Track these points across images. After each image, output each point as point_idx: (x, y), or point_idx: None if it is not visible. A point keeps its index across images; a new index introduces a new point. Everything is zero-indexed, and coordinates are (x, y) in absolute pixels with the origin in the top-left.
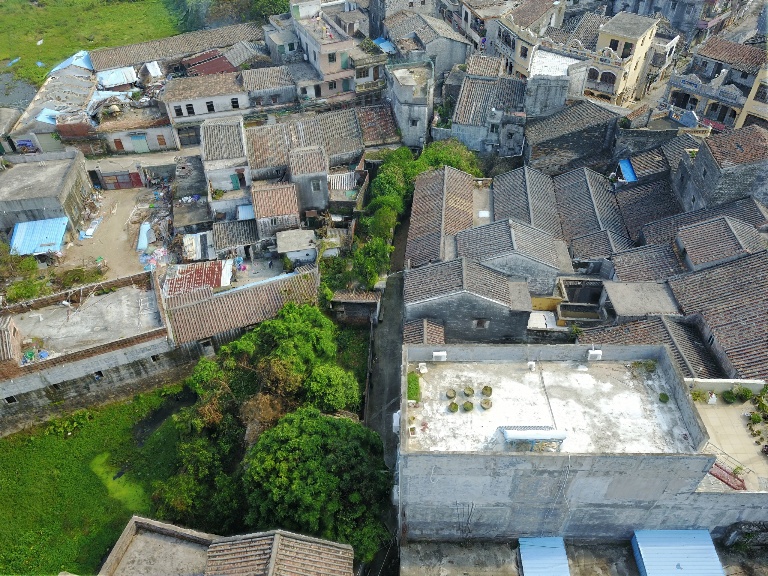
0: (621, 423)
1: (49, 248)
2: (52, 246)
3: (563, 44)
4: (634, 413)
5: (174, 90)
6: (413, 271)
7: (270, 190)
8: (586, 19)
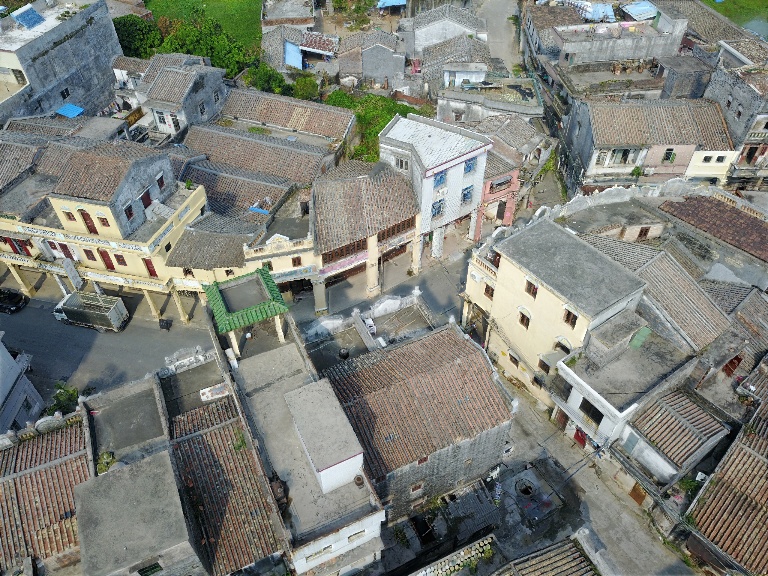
0: (8, 44)
1: (380, 4)
2: (381, 5)
3: (555, 208)
4: (7, 48)
5: (550, 8)
6: (205, 57)
7: (359, 38)
8: (644, 249)
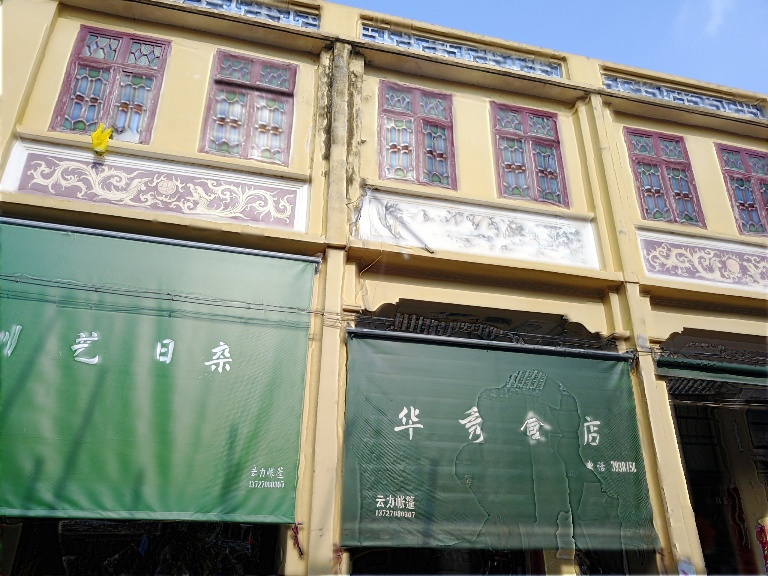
0: None
1: None
2: None
3: None
4: None
5: None
6: None
7: None
8: None
